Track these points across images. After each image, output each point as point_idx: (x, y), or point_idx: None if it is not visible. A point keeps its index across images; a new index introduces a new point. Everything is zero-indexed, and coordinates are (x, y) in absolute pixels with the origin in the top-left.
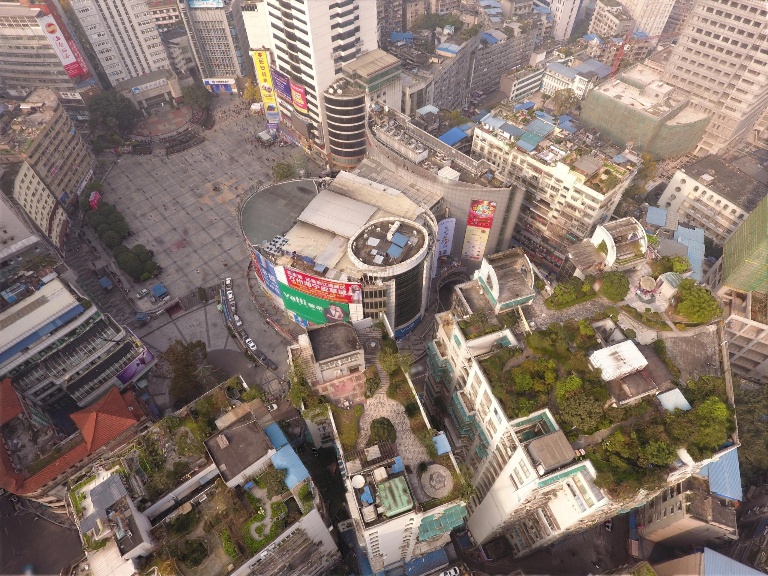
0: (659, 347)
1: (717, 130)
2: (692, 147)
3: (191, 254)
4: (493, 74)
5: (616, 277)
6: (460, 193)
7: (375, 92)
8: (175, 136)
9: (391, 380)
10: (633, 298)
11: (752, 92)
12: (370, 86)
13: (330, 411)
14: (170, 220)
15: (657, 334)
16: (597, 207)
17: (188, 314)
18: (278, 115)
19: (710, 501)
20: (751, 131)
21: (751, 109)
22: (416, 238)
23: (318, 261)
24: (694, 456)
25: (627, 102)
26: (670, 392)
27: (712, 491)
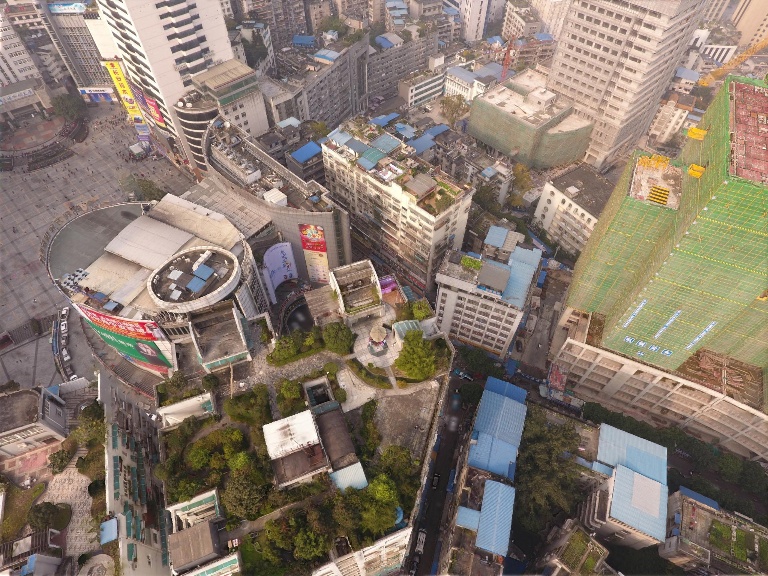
0: (364, 410)
1: (600, 137)
2: (580, 154)
3: (32, 281)
4: (394, 79)
5: (332, 331)
6: (285, 217)
7: (229, 105)
8: (40, 150)
9: (88, 451)
10: (364, 350)
11: (626, 100)
12: (221, 99)
13: (1, 493)
14: (17, 244)
15: (375, 392)
16: (432, 229)
17: (17, 348)
18: (147, 127)
19: (472, 558)
20: (644, 136)
21: (629, 116)
22: (226, 269)
23: (113, 297)
24: (351, 545)
25: (509, 110)
26: (350, 467)
27: (477, 546)
